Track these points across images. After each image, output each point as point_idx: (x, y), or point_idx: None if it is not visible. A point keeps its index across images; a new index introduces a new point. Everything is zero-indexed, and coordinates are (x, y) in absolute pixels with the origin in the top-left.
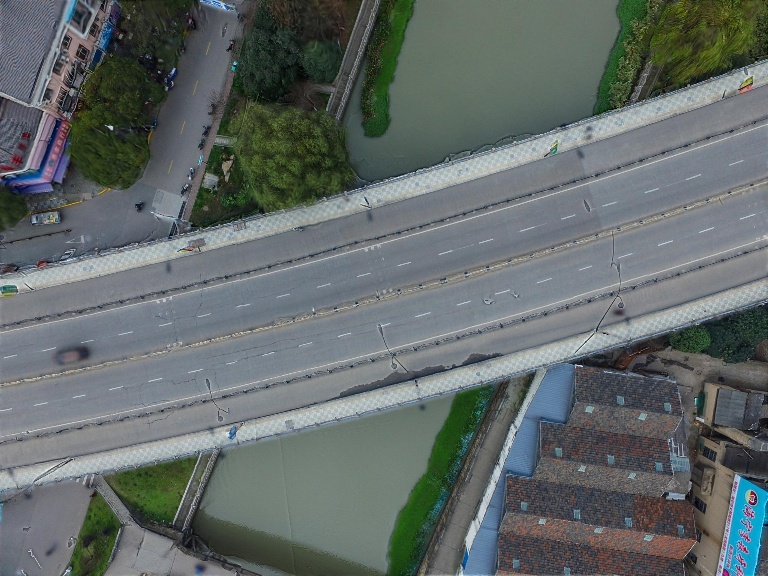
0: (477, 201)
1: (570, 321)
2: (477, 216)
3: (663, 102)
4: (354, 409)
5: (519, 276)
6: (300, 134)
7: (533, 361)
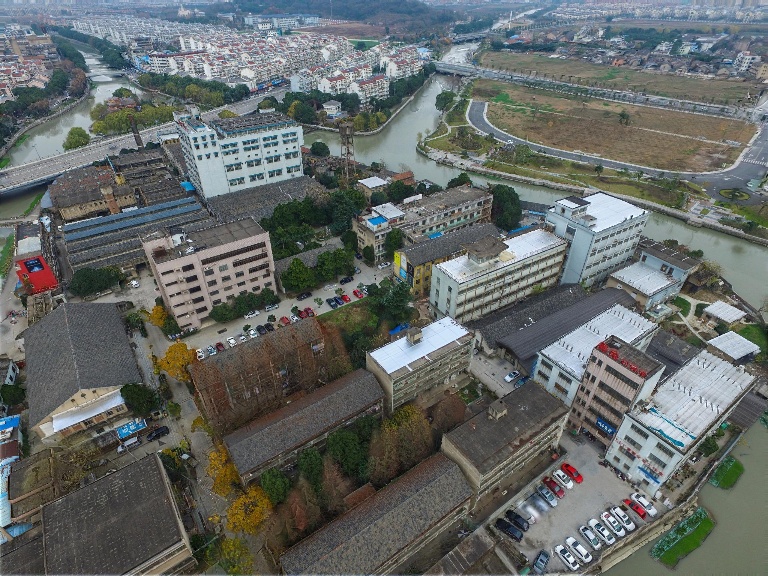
0: None
1: (59, 170)
2: None
3: (71, 151)
4: None
5: (40, 170)
6: None
7: (50, 175)
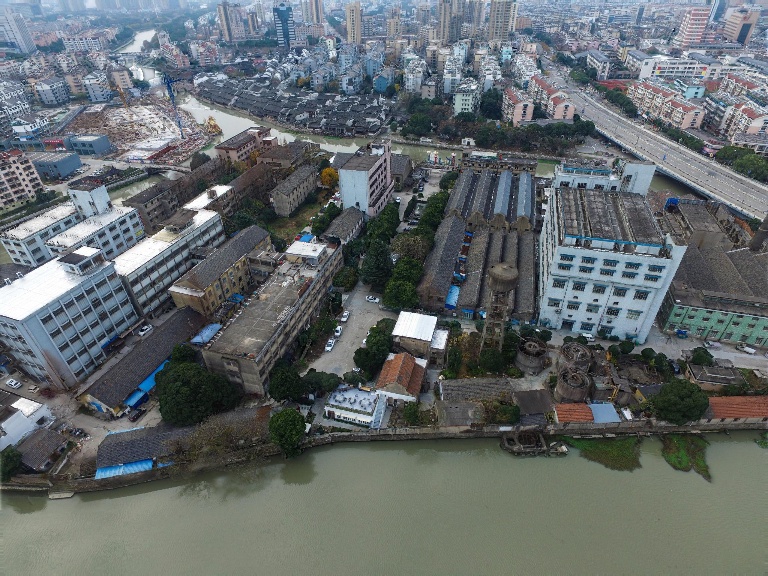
0: (765, 193)
1: None
2: (760, 193)
3: None
4: (679, 176)
5: None
6: (762, 160)
7: None
